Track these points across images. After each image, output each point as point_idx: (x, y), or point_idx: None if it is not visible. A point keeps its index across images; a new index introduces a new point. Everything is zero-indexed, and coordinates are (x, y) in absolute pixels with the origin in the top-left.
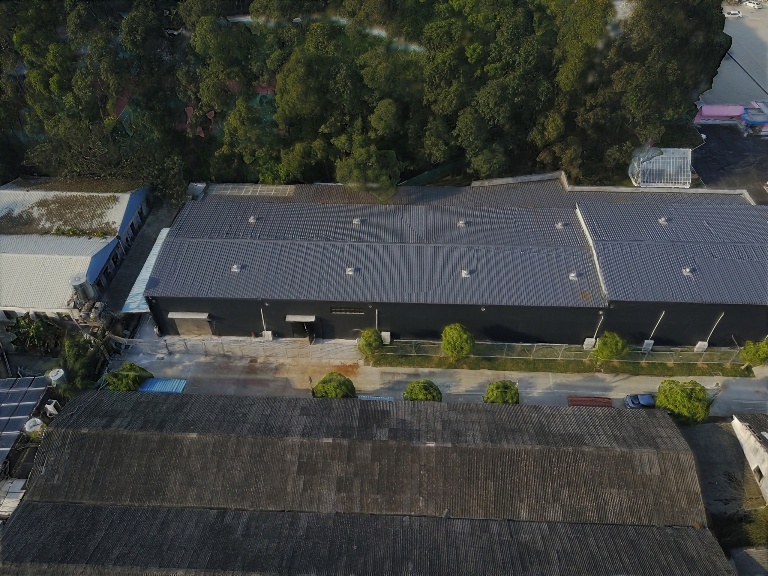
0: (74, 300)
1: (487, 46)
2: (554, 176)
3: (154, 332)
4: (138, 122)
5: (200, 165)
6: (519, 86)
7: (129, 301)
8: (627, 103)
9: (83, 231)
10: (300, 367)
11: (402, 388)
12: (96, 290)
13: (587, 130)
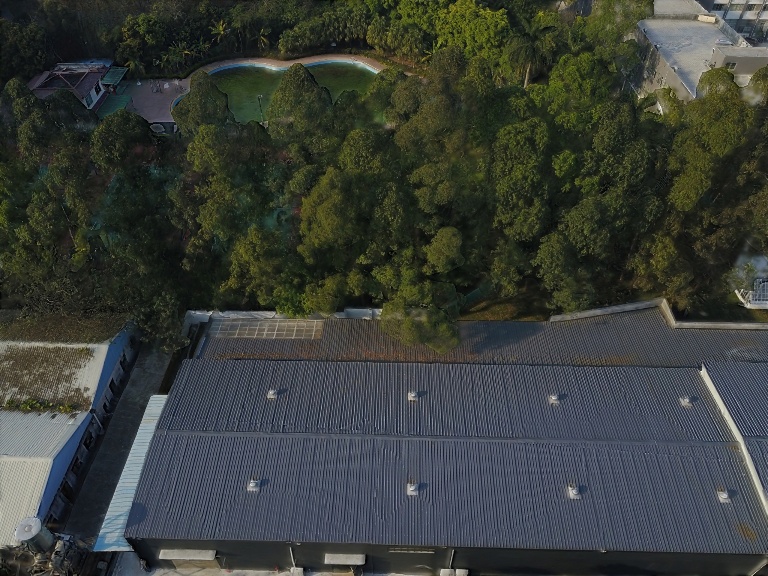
0: (24, 550)
1: (579, 152)
2: (653, 304)
3: (140, 565)
4: (118, 252)
5: (199, 288)
6: (623, 207)
7: (105, 530)
8: (762, 225)
9: (45, 404)
10: None
11: None
12: (61, 498)
13: (709, 260)
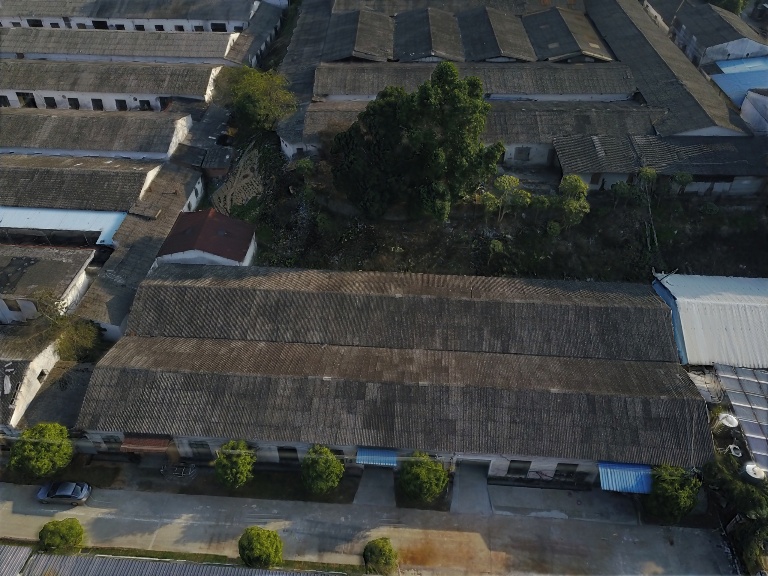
0: None
1: None
2: None
3: None
4: None
5: None
6: None
7: None
8: None
9: None
10: (476, 569)
11: (343, 529)
12: None
13: None
